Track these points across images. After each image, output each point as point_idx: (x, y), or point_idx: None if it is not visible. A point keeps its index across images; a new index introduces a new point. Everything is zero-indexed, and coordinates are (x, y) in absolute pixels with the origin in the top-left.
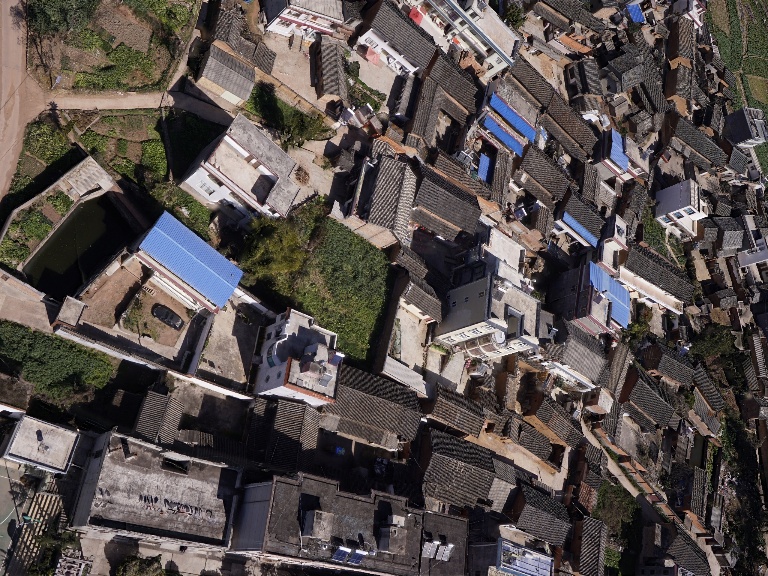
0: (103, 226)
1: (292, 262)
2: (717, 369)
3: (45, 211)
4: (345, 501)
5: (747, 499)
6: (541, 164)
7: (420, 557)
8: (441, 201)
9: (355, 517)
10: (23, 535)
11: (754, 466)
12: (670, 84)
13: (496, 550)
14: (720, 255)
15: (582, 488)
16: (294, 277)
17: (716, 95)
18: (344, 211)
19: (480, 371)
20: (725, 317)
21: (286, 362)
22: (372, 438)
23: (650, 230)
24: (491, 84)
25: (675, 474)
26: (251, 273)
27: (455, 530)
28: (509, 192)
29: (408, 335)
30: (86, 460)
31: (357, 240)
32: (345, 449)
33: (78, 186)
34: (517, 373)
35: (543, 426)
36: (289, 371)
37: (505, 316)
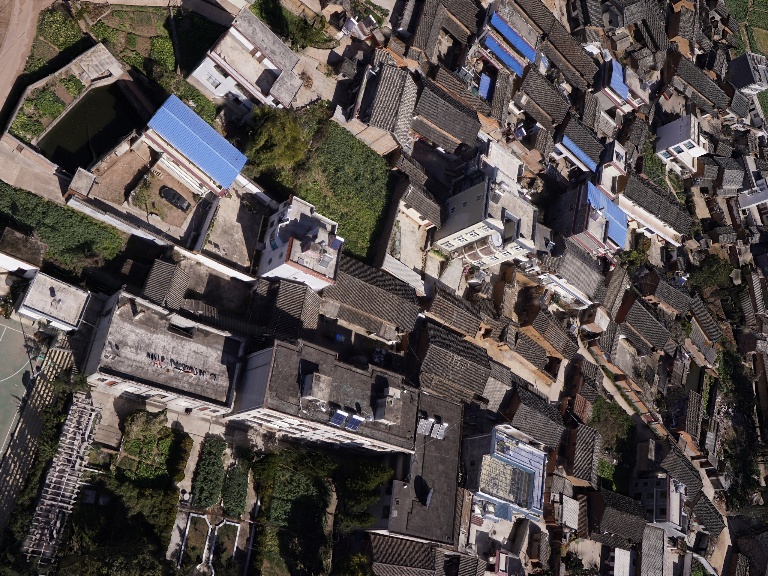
0: (113, 112)
1: (295, 152)
2: (715, 301)
3: (58, 92)
4: (343, 371)
5: (743, 430)
6: (541, 86)
7: (415, 431)
8: (441, 112)
9: (353, 387)
10: (37, 385)
11: (750, 398)
12: (673, 26)
13: (490, 439)
14: (720, 194)
15: (577, 400)
16: (297, 173)
17: (720, 42)
18: (346, 115)
19: (478, 278)
20: (724, 255)
21: (288, 242)
22: (371, 328)
23: (650, 164)
24: (492, 5)
25: (670, 397)
26: (255, 165)
27: (450, 412)
28: (509, 114)
29: (408, 239)
30: (96, 321)
31: (359, 144)
32: (345, 338)
33: (89, 70)
34: (515, 285)
35: (540, 337)
36: (291, 249)
37: (502, 218)
